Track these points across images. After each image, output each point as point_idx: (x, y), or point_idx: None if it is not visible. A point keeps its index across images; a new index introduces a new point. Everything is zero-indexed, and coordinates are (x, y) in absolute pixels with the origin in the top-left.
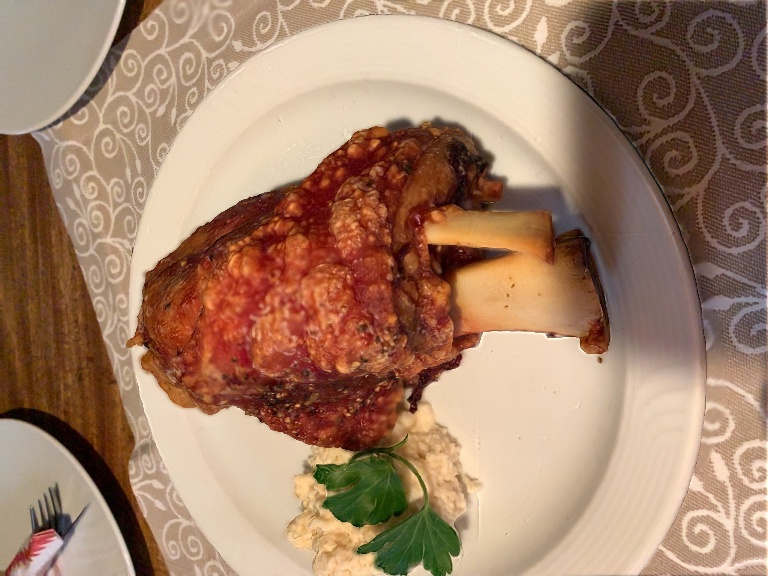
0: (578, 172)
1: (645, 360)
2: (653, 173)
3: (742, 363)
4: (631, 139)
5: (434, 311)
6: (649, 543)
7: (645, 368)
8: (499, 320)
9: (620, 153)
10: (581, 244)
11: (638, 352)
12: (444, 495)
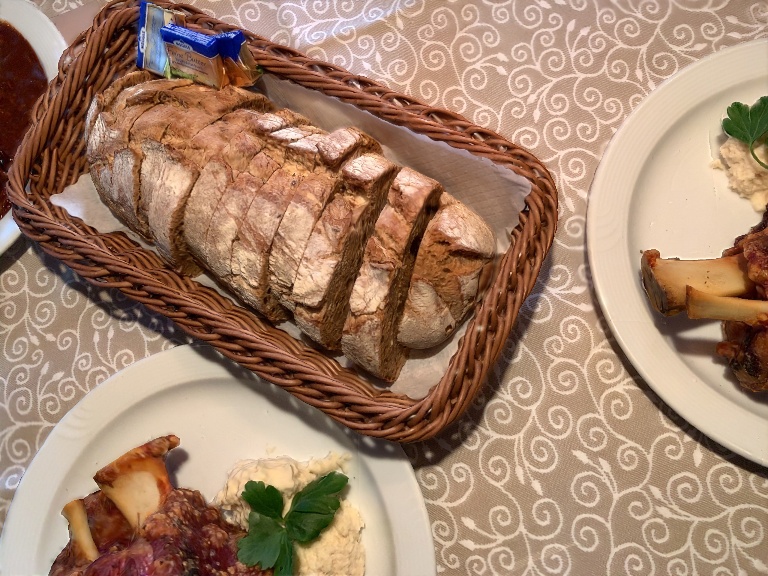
0: (667, 358)
1: (618, 253)
2: (619, 361)
3: (563, 260)
4: (633, 382)
5: (759, 261)
6: (608, 156)
7: (618, 248)
8: (712, 265)
9: (644, 366)
10: (668, 305)
11: (623, 257)
12: (738, 154)
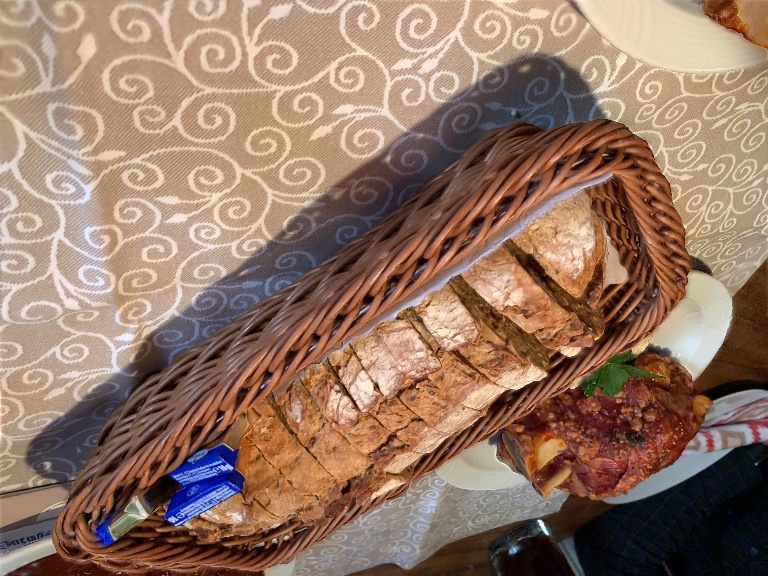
0: None
1: (662, 19)
2: None
3: (583, 56)
4: None
5: None
6: None
7: (658, 16)
8: None
9: None
10: None
11: (668, 16)
12: None
